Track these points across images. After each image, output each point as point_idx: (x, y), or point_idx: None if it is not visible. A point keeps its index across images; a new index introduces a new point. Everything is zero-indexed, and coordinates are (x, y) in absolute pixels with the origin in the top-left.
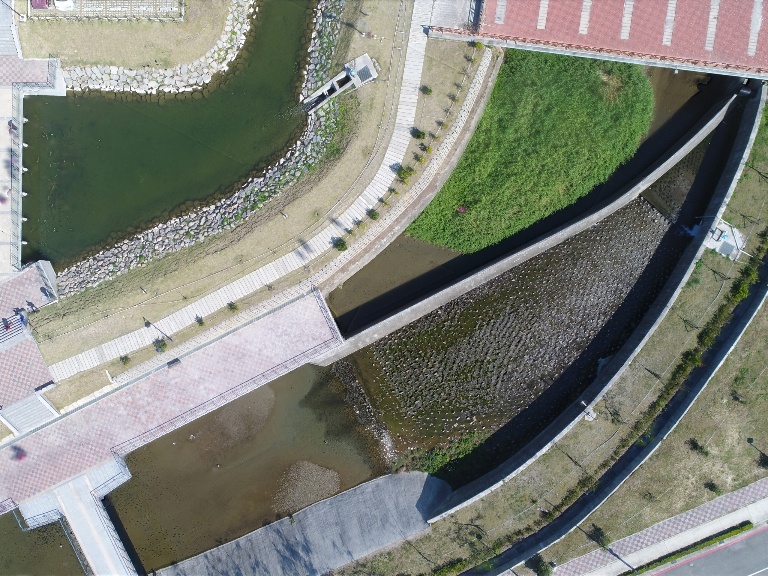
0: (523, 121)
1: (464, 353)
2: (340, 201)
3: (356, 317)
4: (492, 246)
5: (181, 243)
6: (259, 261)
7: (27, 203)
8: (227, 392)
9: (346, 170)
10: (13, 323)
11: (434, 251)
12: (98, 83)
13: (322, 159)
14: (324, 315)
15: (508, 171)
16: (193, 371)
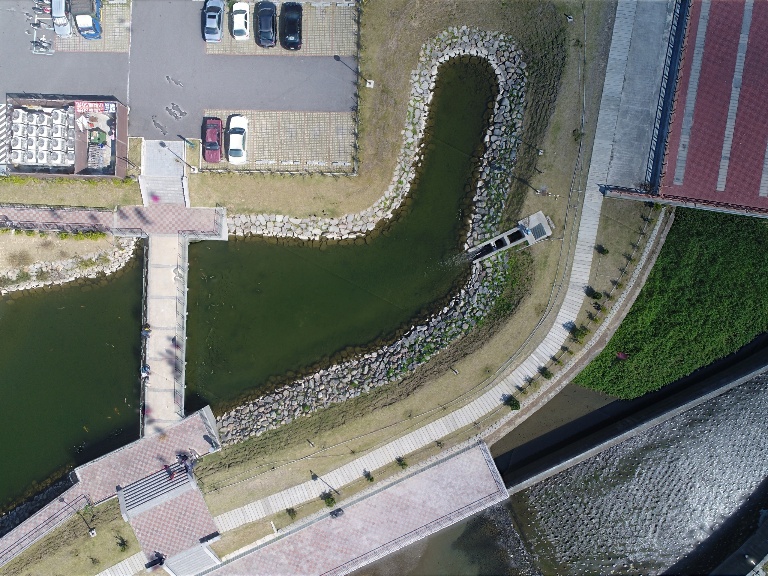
0: (688, 271)
1: (622, 500)
2: (512, 358)
3: (513, 462)
4: (651, 393)
5: (346, 394)
6: (429, 417)
7: (188, 348)
8: (390, 543)
9: (518, 327)
10: (177, 471)
11: (591, 395)
12: (261, 229)
13: (491, 313)
14: (490, 468)
15: (671, 320)
16: (356, 521)
